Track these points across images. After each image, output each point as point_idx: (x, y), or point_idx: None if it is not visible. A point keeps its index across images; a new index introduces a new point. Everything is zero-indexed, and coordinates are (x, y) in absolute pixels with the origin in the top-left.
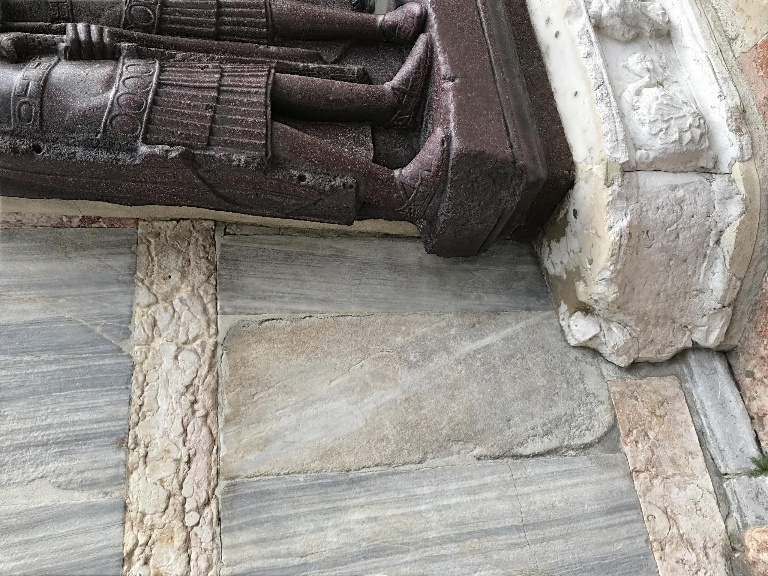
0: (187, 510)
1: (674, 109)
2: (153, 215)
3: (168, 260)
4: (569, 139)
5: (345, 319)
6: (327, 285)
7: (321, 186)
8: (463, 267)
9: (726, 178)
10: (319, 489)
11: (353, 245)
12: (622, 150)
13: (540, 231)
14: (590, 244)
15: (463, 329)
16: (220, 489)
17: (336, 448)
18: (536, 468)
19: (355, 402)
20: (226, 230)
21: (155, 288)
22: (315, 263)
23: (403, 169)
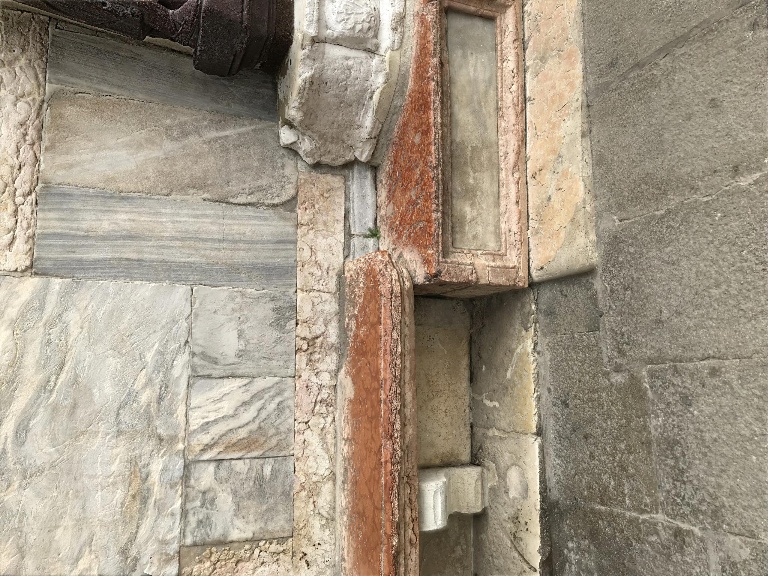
0: (17, 196)
1: (357, 7)
2: (4, 4)
3: (13, 39)
4: (295, 11)
5: (134, 102)
6: (125, 77)
7: (117, 12)
8: (222, 83)
9: (381, 59)
10: (101, 199)
11: (148, 53)
12: (314, 28)
13: (279, 68)
14: (292, 84)
15: (213, 123)
16: (39, 188)
17: (115, 178)
18: (239, 211)
19: (132, 154)
20: (57, 25)
21: (3, 57)
22: (119, 61)
23: (175, 11)
